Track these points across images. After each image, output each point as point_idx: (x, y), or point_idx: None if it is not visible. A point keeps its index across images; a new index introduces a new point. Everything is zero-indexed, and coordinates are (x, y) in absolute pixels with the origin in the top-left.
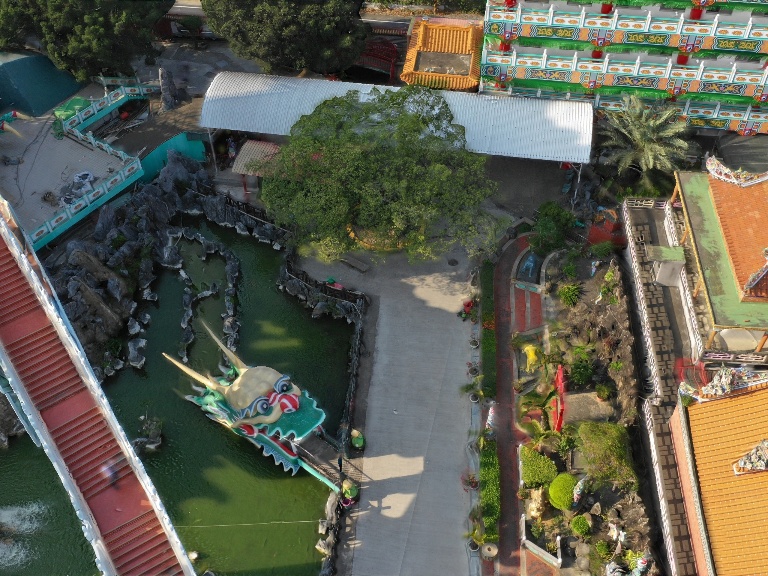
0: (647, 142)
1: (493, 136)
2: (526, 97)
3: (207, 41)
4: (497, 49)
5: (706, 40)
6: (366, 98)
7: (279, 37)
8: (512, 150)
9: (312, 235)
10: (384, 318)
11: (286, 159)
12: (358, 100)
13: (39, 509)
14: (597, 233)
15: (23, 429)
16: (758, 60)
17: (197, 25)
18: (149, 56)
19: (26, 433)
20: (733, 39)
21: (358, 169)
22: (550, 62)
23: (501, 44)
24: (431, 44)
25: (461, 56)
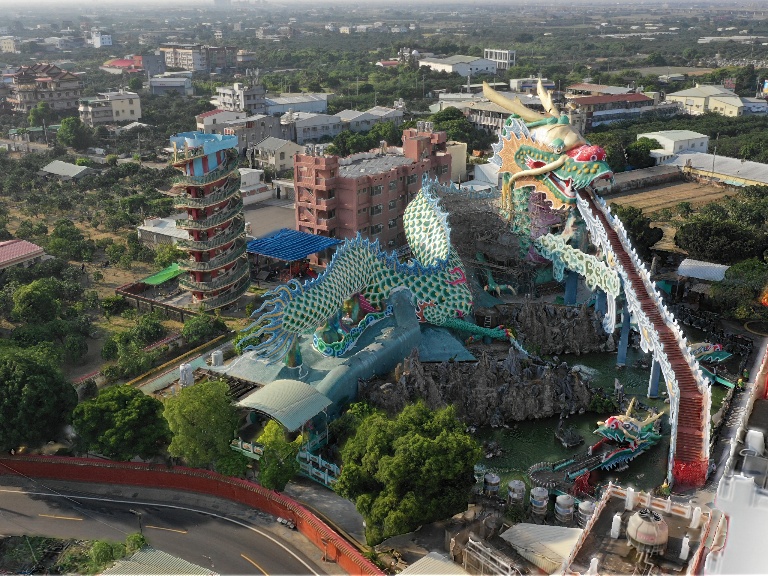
0: None
1: None
2: None
3: (669, 264)
4: None
5: None
6: None
7: (721, 249)
8: None
9: (732, 308)
10: (762, 353)
11: (727, 273)
12: None
13: (595, 371)
14: None
15: (586, 351)
16: None
17: (668, 254)
18: (646, 256)
19: (587, 354)
20: None
21: (761, 282)
22: None
23: None
24: None
25: None
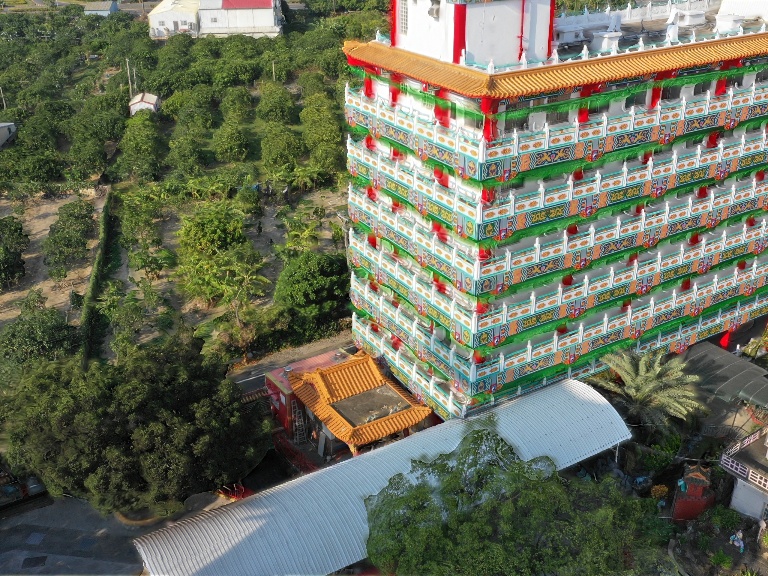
0: (652, 392)
1: (534, 455)
2: (509, 400)
3: None
4: (475, 361)
5: (655, 277)
6: (414, 478)
7: (190, 459)
8: (562, 461)
9: None
10: None
11: None
12: (412, 485)
13: None
14: (686, 505)
15: None
16: (677, 281)
17: None
18: None
19: None
20: (673, 268)
21: (518, 571)
22: (534, 352)
23: (479, 354)
24: (337, 391)
25: (377, 390)
